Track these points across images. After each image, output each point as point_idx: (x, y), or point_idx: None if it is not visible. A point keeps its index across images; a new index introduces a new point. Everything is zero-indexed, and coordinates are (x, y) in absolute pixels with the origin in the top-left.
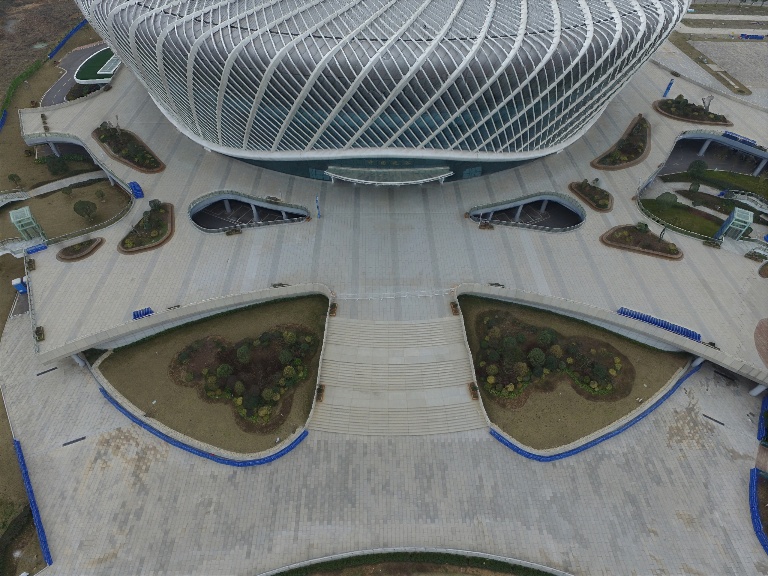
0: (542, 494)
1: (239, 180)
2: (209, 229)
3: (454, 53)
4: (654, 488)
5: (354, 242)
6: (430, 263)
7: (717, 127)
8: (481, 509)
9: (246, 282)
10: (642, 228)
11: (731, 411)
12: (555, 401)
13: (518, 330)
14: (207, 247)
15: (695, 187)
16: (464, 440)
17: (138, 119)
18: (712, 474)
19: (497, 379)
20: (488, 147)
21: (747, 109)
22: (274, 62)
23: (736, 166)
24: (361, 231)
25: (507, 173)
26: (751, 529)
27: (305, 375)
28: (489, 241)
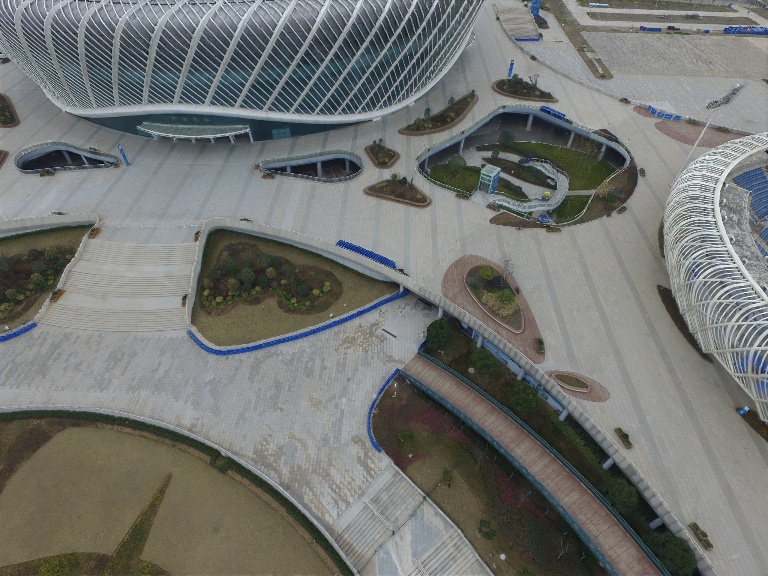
0: (204, 378)
1: (76, 135)
2: (24, 170)
3: (192, 15)
4: (302, 379)
5: (145, 185)
6: (201, 202)
7: (541, 103)
8: (146, 385)
9: (35, 211)
10: (394, 179)
11: (410, 328)
12: (255, 312)
13: (253, 258)
14: (18, 184)
15: (494, 154)
16: (163, 337)
17: (19, 86)
18: (360, 372)
19: (210, 292)
20: (277, 107)
21: (582, 89)
22: (46, 21)
23: (555, 139)
24: (157, 177)
25: (316, 136)
26: (366, 412)
27: (55, 283)
28: (264, 188)
